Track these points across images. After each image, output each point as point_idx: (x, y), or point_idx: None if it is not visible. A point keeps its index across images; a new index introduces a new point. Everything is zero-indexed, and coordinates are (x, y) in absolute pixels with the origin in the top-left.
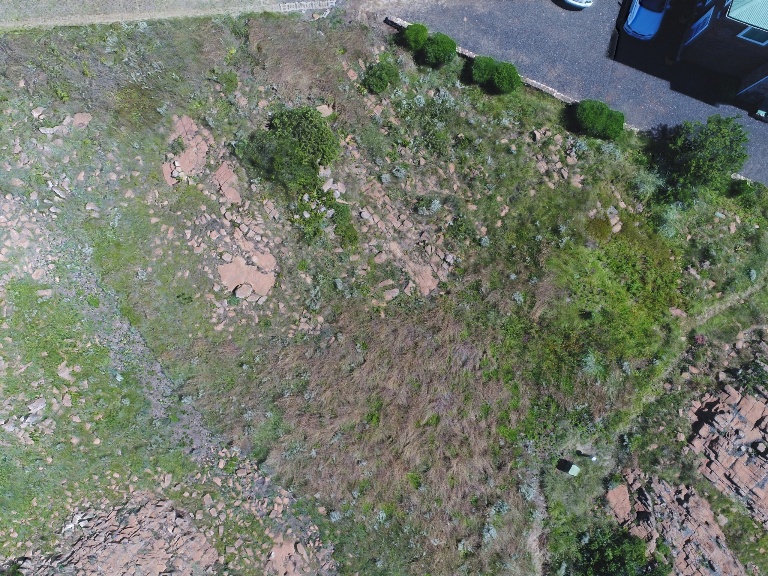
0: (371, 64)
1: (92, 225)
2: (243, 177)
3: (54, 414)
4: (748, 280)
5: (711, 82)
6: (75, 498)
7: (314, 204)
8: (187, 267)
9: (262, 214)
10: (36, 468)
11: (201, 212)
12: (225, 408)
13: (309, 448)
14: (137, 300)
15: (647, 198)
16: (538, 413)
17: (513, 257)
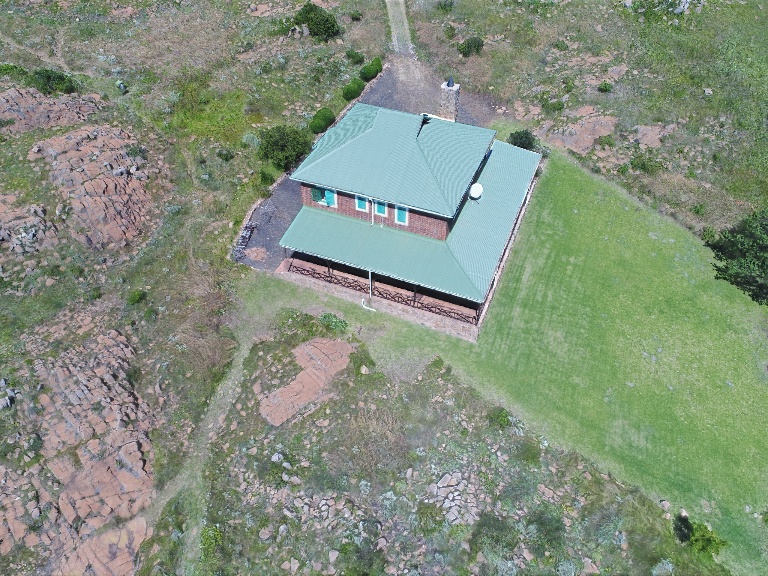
0: (362, 54)
1: None
2: None
3: None
4: None
5: None
6: None
7: None
8: None
9: None
10: None
11: None
12: None
13: (174, 18)
14: None
15: None
16: None
17: None
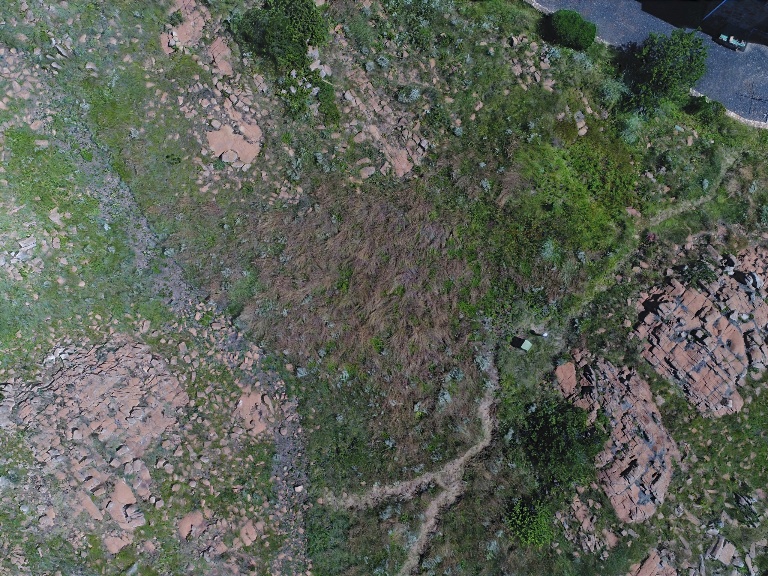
0: None
1: (90, 84)
2: (236, 51)
3: (43, 255)
4: (701, 189)
5: (680, 6)
6: (58, 334)
7: (301, 81)
8: (178, 130)
9: (251, 86)
10: (23, 303)
11: (194, 81)
12: (205, 263)
13: (281, 307)
14: (128, 157)
15: (612, 105)
16: (497, 293)
17: (484, 148)
